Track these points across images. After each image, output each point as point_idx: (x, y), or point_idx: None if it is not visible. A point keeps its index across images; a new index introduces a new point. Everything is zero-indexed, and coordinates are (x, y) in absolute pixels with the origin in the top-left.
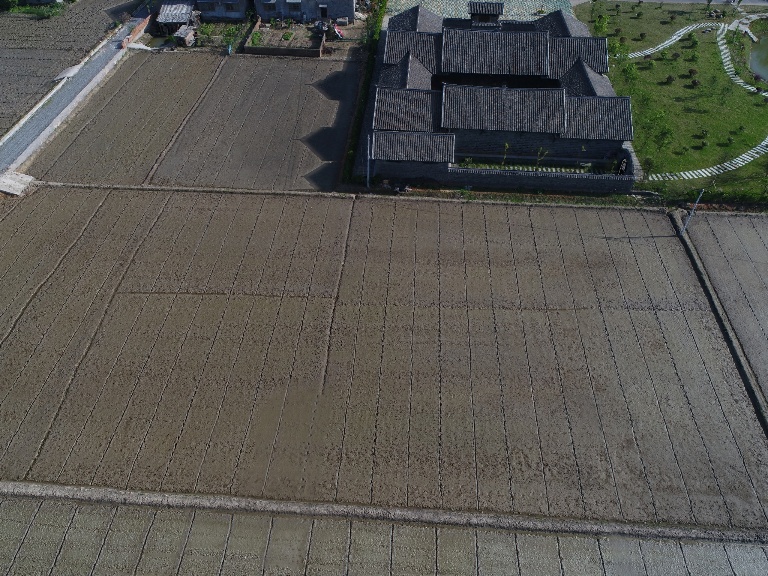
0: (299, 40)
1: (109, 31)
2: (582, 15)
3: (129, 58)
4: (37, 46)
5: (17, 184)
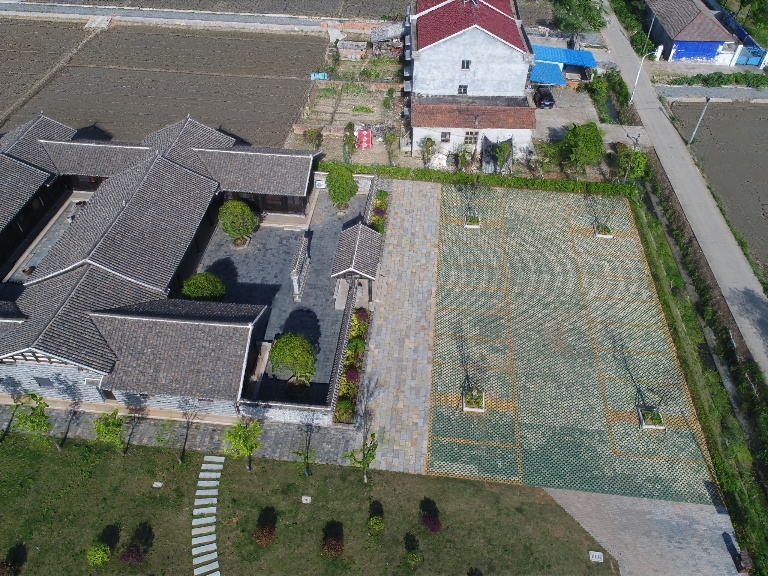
0: (352, 118)
1: (370, 18)
2: (476, 495)
3: (315, 36)
4: (350, 1)
5: (97, 23)
